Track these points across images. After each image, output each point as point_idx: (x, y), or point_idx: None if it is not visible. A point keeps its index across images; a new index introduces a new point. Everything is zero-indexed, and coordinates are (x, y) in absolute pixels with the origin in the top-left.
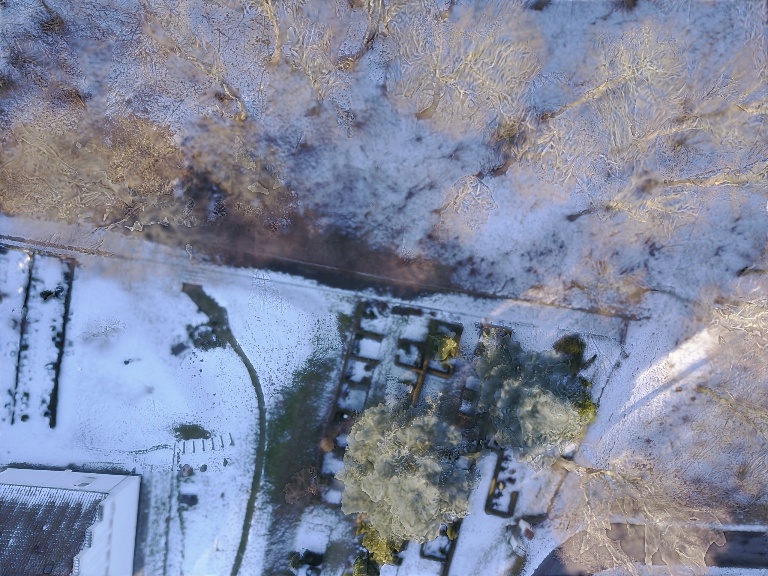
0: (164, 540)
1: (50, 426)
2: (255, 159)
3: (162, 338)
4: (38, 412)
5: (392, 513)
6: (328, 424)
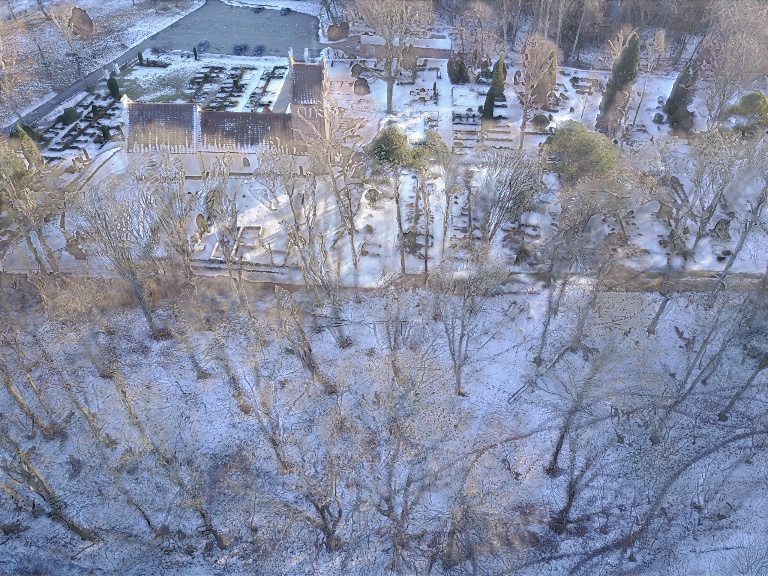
0: None
1: None
2: (2, 313)
3: None
4: None
5: None
6: None
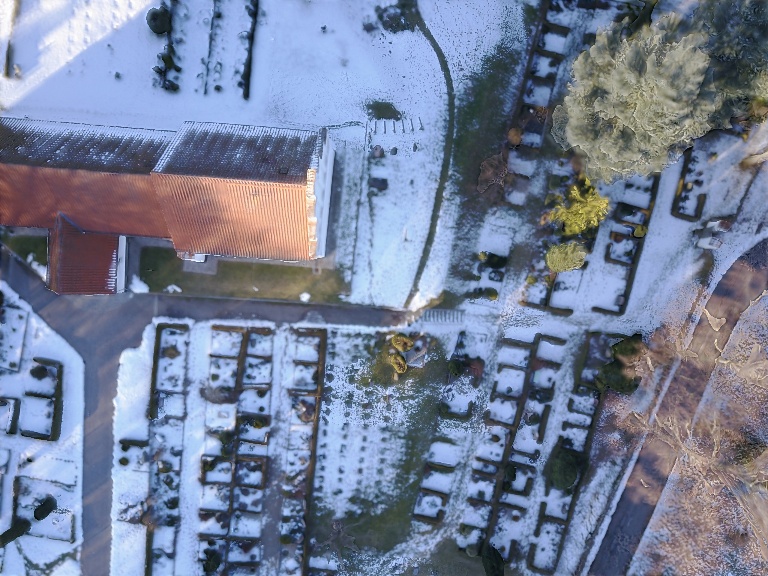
0: (355, 224)
1: (244, 95)
2: None
3: (353, 13)
4: (231, 83)
5: (636, 117)
6: (512, 122)
